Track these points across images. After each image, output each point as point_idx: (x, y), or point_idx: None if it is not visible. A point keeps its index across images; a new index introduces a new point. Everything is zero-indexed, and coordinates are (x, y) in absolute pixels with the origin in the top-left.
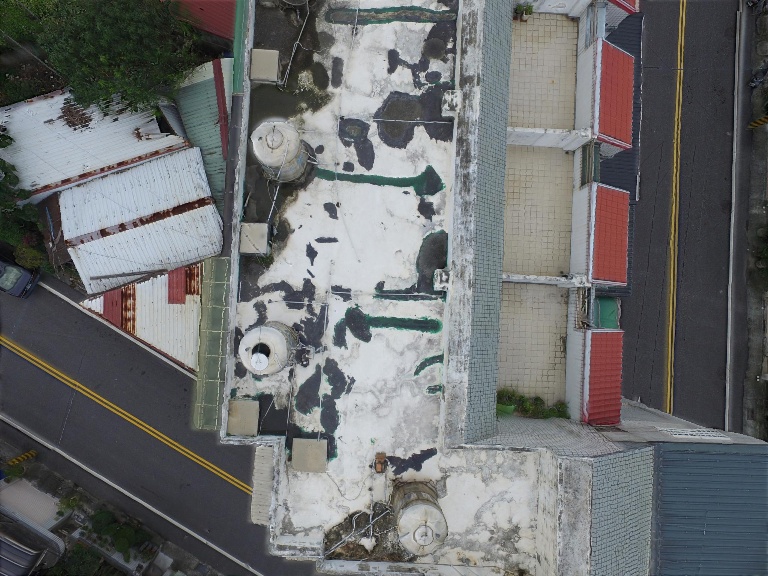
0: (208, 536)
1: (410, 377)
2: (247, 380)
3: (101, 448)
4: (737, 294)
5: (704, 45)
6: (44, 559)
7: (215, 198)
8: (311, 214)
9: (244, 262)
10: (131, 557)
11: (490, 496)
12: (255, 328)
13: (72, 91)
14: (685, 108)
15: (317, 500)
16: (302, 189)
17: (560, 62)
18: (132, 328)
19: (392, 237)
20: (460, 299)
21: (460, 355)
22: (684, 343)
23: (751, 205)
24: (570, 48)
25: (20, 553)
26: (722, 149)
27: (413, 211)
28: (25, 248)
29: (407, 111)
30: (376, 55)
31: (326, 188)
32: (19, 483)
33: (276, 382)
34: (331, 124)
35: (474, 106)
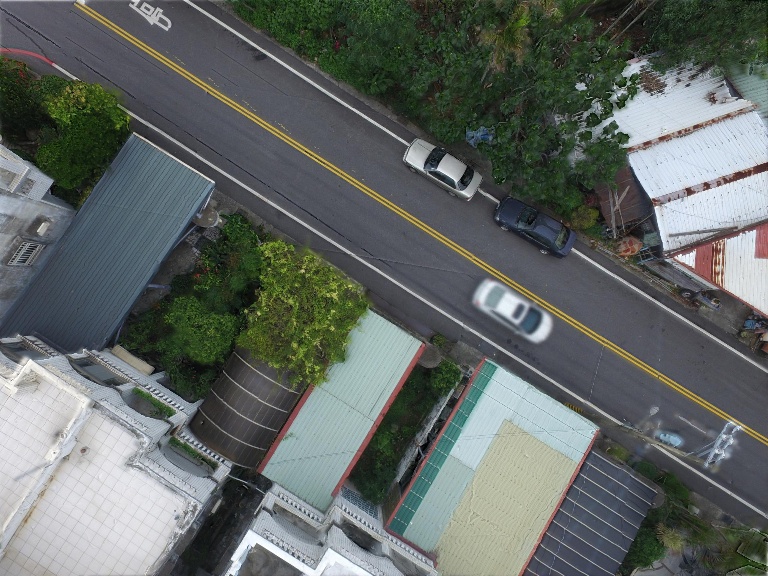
0: (731, 487)
1: None
2: None
3: (629, 402)
4: None
5: None
6: (653, 499)
7: None
8: None
9: None
10: None
11: None
12: None
13: (657, 58)
14: None
15: None
16: None
17: None
18: (721, 281)
19: None
20: None
21: None
22: None
23: None
24: None
25: (649, 491)
26: None
27: None
28: (590, 208)
29: None
30: None
31: None
32: None
33: None
34: None
35: None
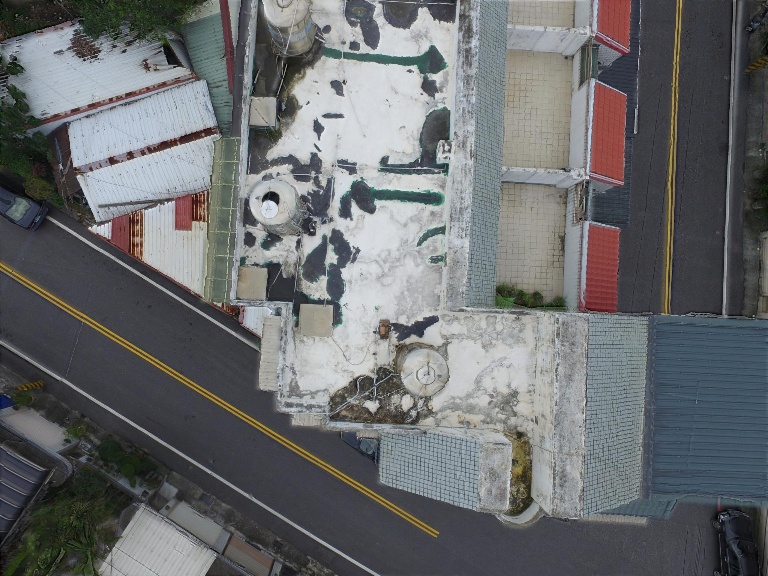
0: (212, 467)
1: (413, 247)
2: (256, 250)
3: (108, 379)
4: (733, 235)
5: None
6: (53, 477)
7: (221, 130)
8: (318, 91)
9: (253, 136)
10: (137, 483)
11: (490, 362)
12: (265, 181)
13: (82, 21)
14: (683, 52)
15: (323, 365)
16: (310, 67)
17: None
18: (139, 254)
19: (396, 113)
20: (462, 168)
21: (461, 221)
22: (681, 283)
23: (748, 148)
24: None
25: (29, 469)
26: (719, 93)
27: (417, 89)
28: (34, 178)
29: None
30: None
31: (333, 66)
32: (27, 412)
33: (284, 252)
34: (338, 5)
35: None
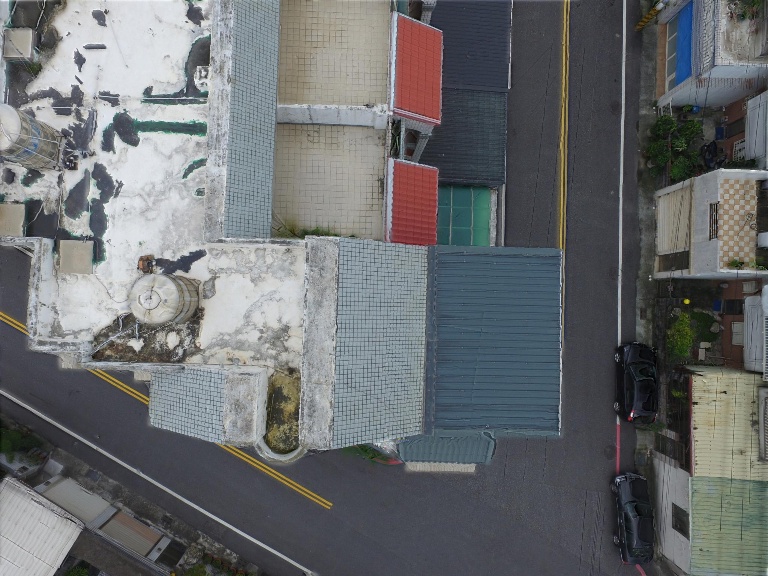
0: (98, 442)
1: (179, 180)
2: (16, 186)
3: None
4: (628, 195)
5: None
6: None
7: None
8: (79, 21)
9: (11, 69)
10: (16, 459)
11: (259, 296)
12: None
13: None
14: (574, 11)
15: (87, 304)
16: None
17: None
18: None
19: (160, 42)
20: (218, 94)
21: (218, 149)
22: (576, 244)
23: (641, 106)
24: None
25: None
26: (611, 51)
27: (182, 17)
28: None
29: None
30: None
31: None
32: None
33: (45, 188)
34: None
35: None
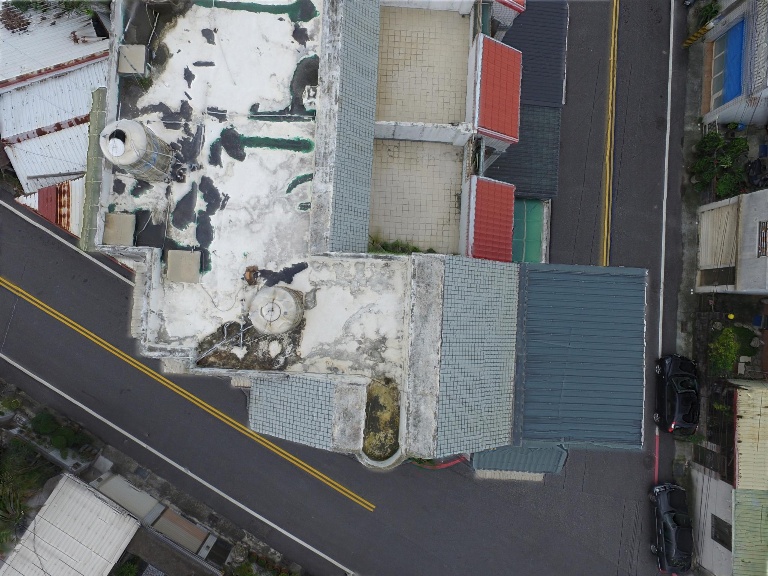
0: (148, 440)
1: (282, 194)
2: (126, 197)
3: (43, 353)
4: (672, 209)
5: None
6: None
7: None
8: (189, 39)
9: (124, 84)
10: (69, 456)
11: (358, 308)
12: (116, 121)
13: None
14: (622, 27)
15: (192, 312)
16: (181, 16)
17: None
18: (66, 224)
19: (267, 61)
20: (326, 113)
21: (325, 166)
22: (619, 257)
23: (686, 122)
24: None
25: None
26: (658, 67)
27: (288, 37)
28: None
29: None
30: None
31: (204, 15)
32: None
33: (154, 199)
34: None
35: None
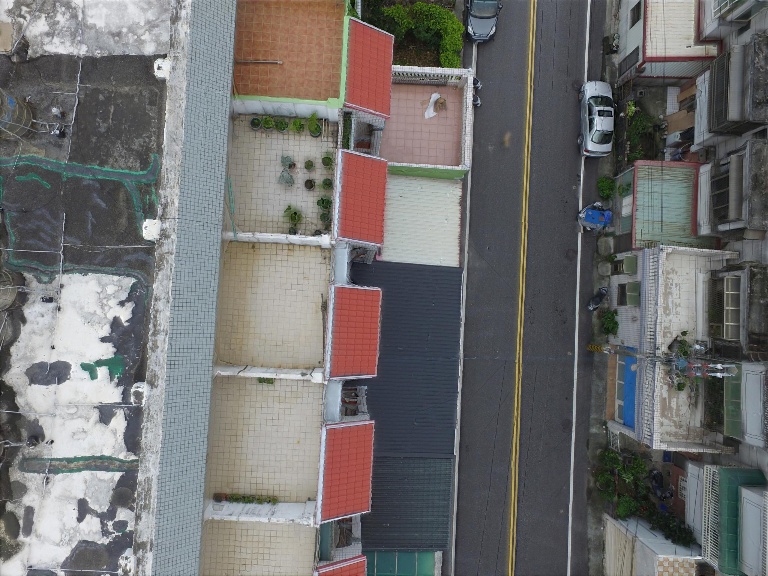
0: None
1: None
2: None
3: None
4: (578, 513)
5: (546, 266)
6: None
7: None
8: None
9: None
10: None
11: None
12: None
13: None
14: (527, 329)
15: None
16: None
17: (306, 422)
18: None
19: None
20: None
21: None
22: (525, 563)
23: (592, 424)
24: (316, 408)
25: None
26: (563, 369)
27: None
28: None
29: (94, 560)
30: (66, 504)
31: None
32: None
33: None
34: (20, 574)
35: (147, 572)
